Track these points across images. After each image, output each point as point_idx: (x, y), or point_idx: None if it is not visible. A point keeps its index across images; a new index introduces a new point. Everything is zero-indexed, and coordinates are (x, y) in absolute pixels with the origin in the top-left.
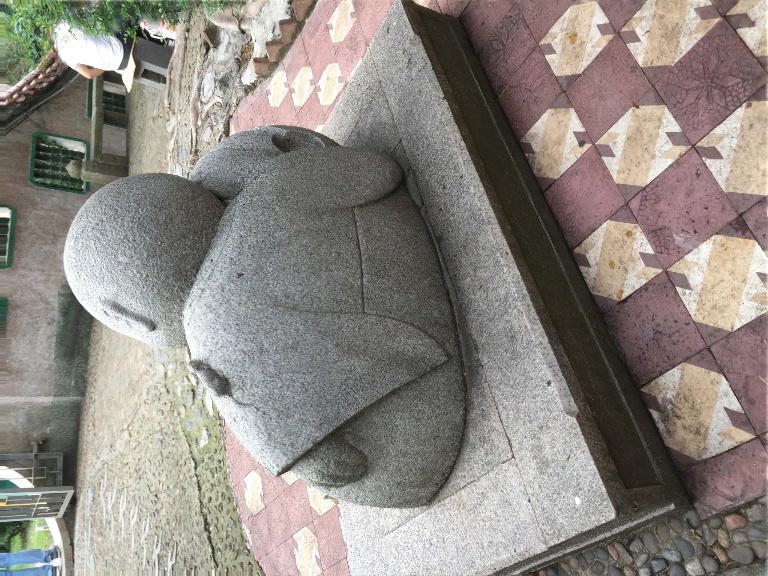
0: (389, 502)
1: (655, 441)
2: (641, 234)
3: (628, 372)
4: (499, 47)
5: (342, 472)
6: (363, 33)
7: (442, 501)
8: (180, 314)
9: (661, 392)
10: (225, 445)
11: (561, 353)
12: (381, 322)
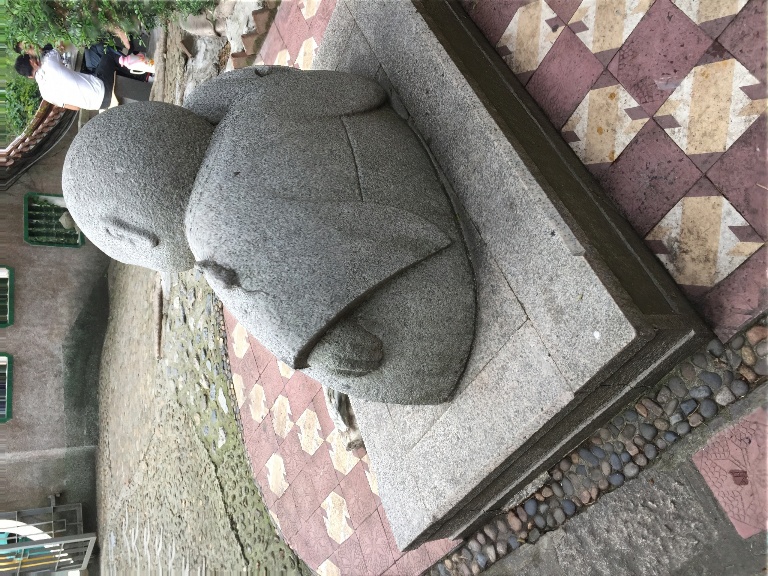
0: (410, 396)
1: (666, 280)
2: (624, 92)
3: (630, 226)
4: None
5: (359, 356)
6: (334, 1)
7: (464, 391)
8: (181, 224)
9: (665, 234)
10: (243, 438)
11: (561, 206)
12: (380, 208)
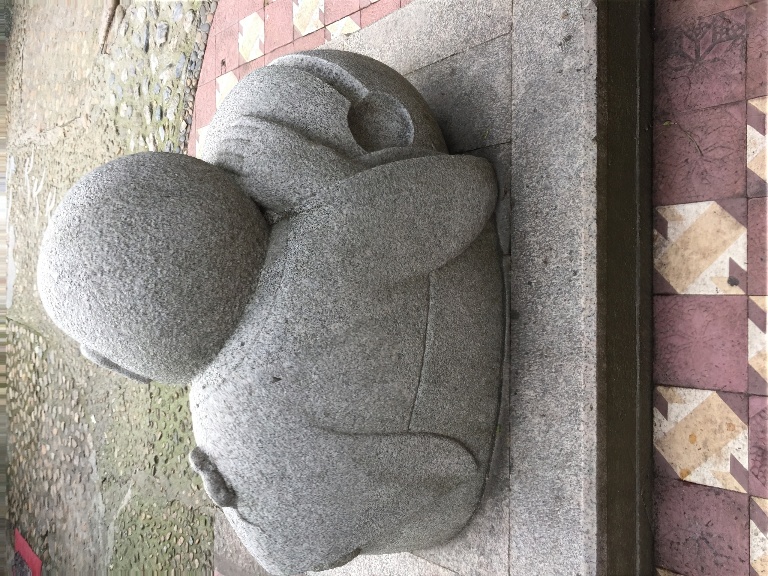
0: None
1: None
2: (745, 439)
3: (652, 545)
4: (690, 53)
5: None
6: None
7: (415, 556)
8: (188, 381)
9: None
10: None
11: (603, 545)
12: (423, 443)
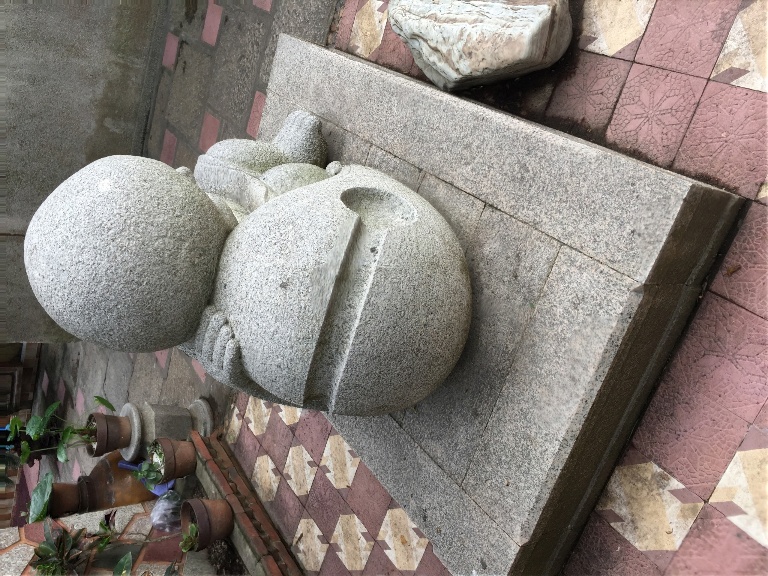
0: None
1: None
2: None
3: None
4: None
5: None
6: None
7: None
8: None
9: None
10: None
11: None
12: None
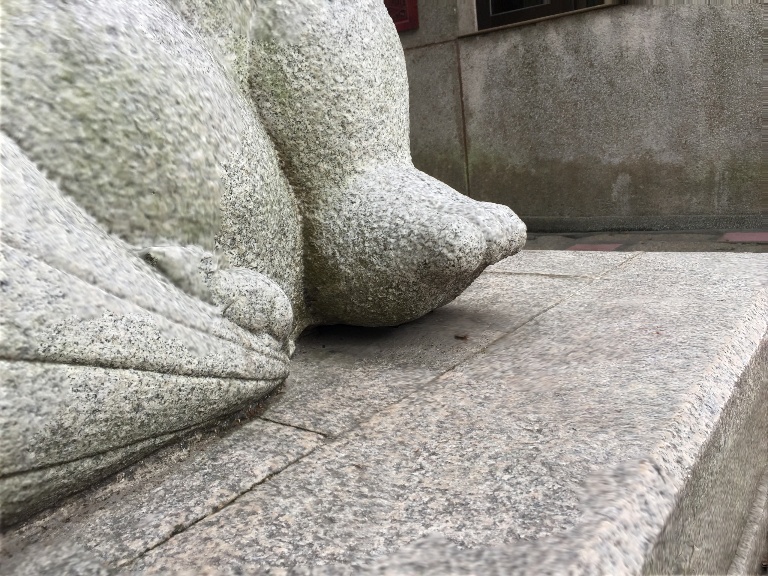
0: None
1: None
2: None
3: None
4: None
5: None
6: None
7: None
8: None
9: None
10: None
11: None
12: None
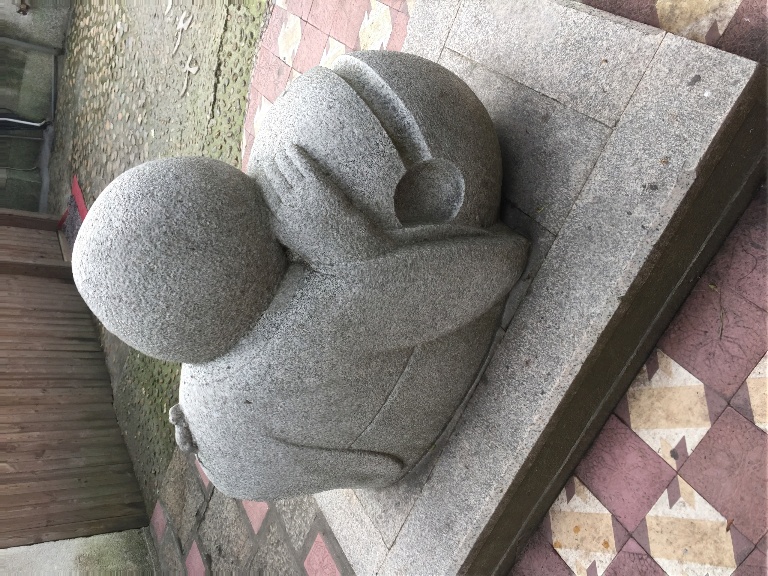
0: None
1: None
2: (610, 560)
3: (511, 567)
4: None
5: None
6: None
7: None
8: None
9: None
10: (263, 33)
11: (464, 571)
12: (358, 458)
